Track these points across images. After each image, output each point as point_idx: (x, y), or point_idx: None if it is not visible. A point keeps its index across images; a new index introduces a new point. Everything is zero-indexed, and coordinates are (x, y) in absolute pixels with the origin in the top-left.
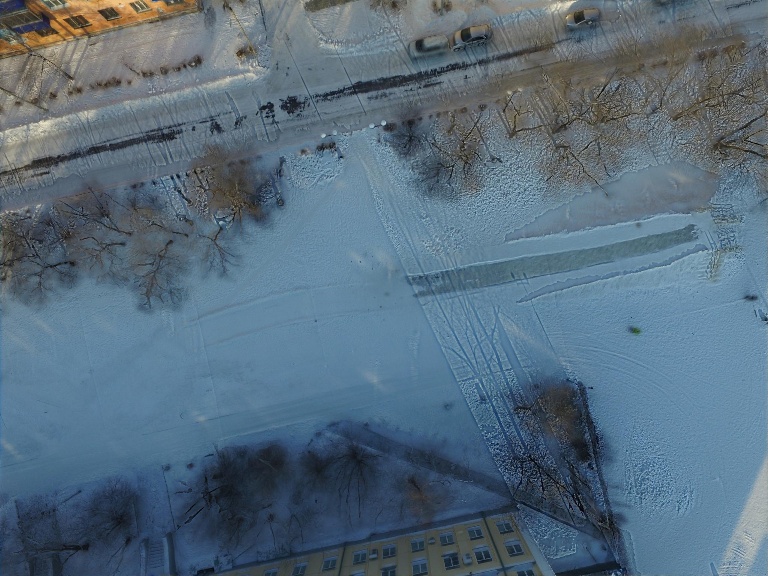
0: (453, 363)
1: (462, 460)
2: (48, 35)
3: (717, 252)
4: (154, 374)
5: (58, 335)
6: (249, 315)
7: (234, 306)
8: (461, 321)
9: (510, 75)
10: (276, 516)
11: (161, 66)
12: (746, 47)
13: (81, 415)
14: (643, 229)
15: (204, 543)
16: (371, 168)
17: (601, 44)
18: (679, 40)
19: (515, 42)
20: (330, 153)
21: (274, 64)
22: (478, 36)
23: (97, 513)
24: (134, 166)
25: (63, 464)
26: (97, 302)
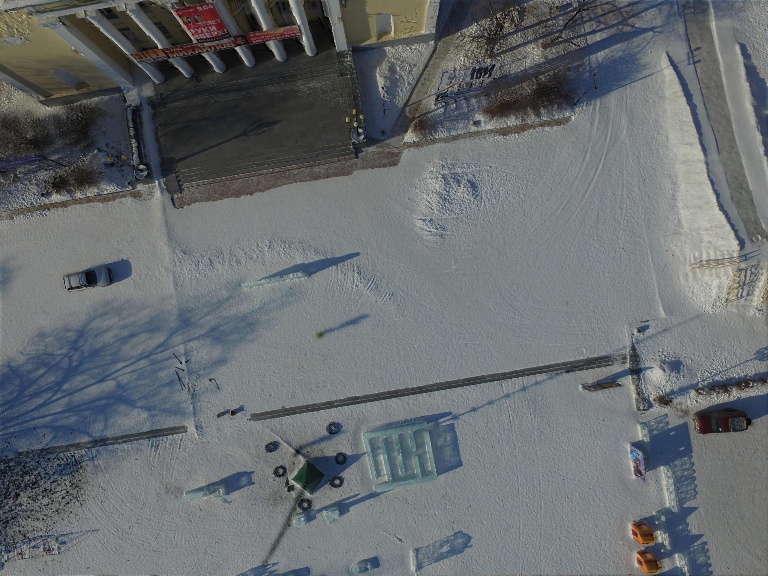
0: None
1: None
2: None
3: (735, 262)
4: None
5: None
6: None
7: None
8: None
9: None
10: None
11: None
12: None
13: None
14: (760, 185)
15: None
16: None
17: None
18: None
19: None
20: None
21: None
22: None
23: None
24: None
25: None
26: None
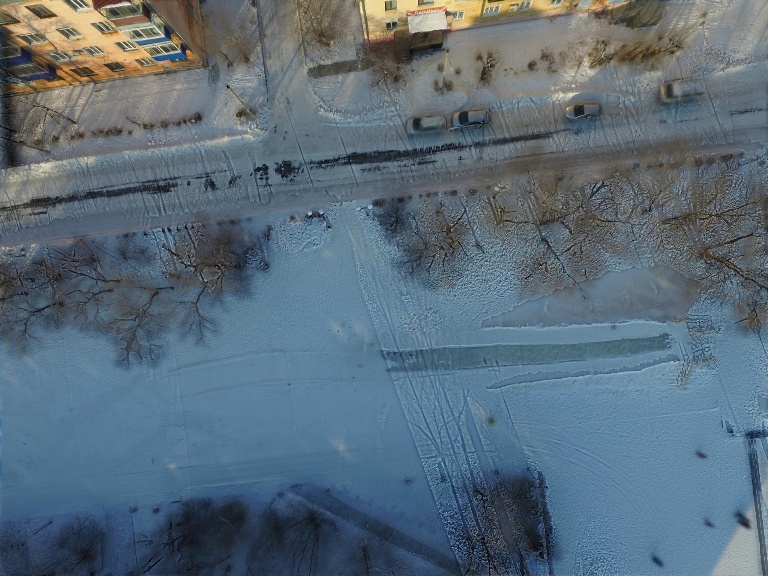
0: (418, 440)
1: (417, 534)
2: (55, 80)
3: (689, 364)
4: (130, 418)
5: (42, 371)
6: (226, 371)
7: (212, 361)
8: (430, 400)
9: (504, 160)
10: (234, 567)
11: (162, 119)
12: (744, 158)
13: (58, 450)
14: (618, 332)
15: None
16: (357, 240)
17: (599, 138)
18: (678, 142)
19: (513, 128)
20: (319, 222)
21: (272, 127)
22: (475, 121)
23: (65, 545)
24: (128, 214)
25: (38, 494)
26: (82, 343)
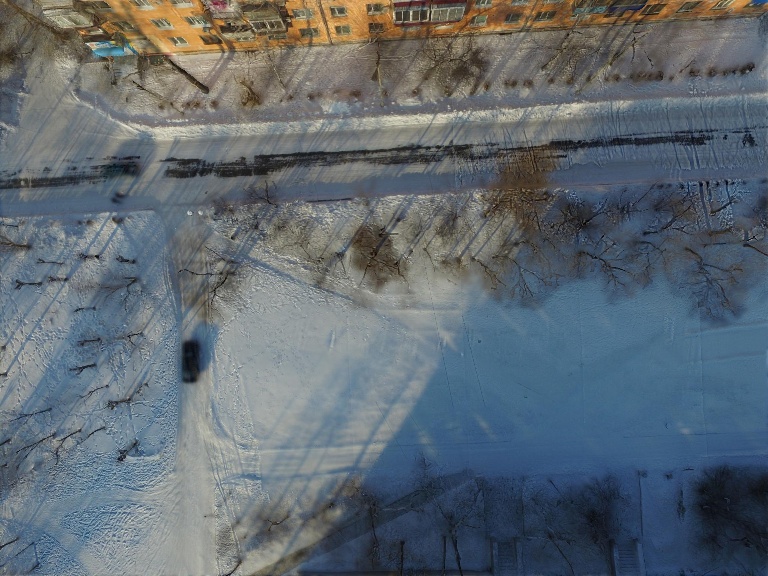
0: None
1: None
2: (609, 17)
3: None
4: (643, 379)
5: (553, 323)
6: (753, 337)
7: (741, 325)
8: None
9: None
10: None
11: (706, 67)
12: None
13: (561, 406)
14: None
15: (671, 555)
16: None
17: None
18: None
19: None
20: None
21: None
22: None
23: (570, 507)
24: (657, 165)
25: (535, 451)
26: (598, 297)
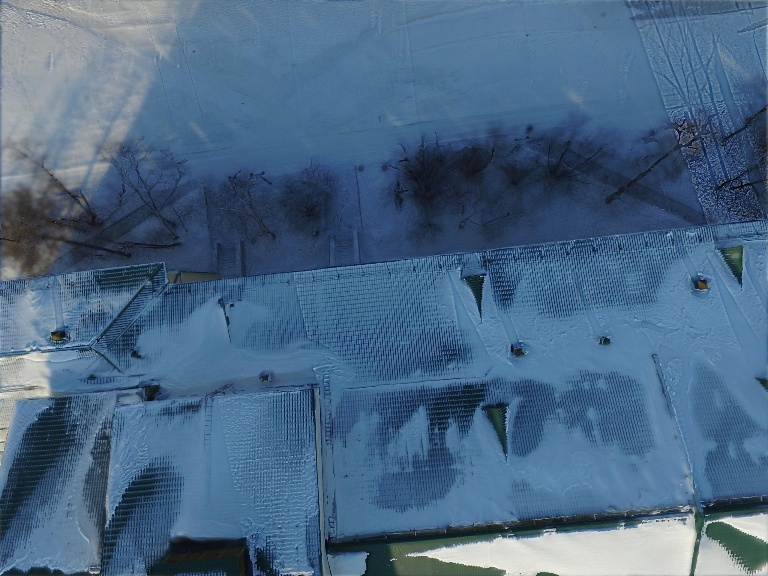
0: (664, 89)
1: (662, 187)
2: None
3: None
4: (355, 75)
5: (263, 26)
6: (458, 25)
7: (445, 13)
8: (677, 47)
9: None
10: (467, 224)
11: None
12: None
13: (278, 110)
14: None
15: (391, 245)
16: None
17: None
18: None
19: None
20: None
21: None
22: None
23: (288, 203)
24: None
25: (255, 156)
26: None
